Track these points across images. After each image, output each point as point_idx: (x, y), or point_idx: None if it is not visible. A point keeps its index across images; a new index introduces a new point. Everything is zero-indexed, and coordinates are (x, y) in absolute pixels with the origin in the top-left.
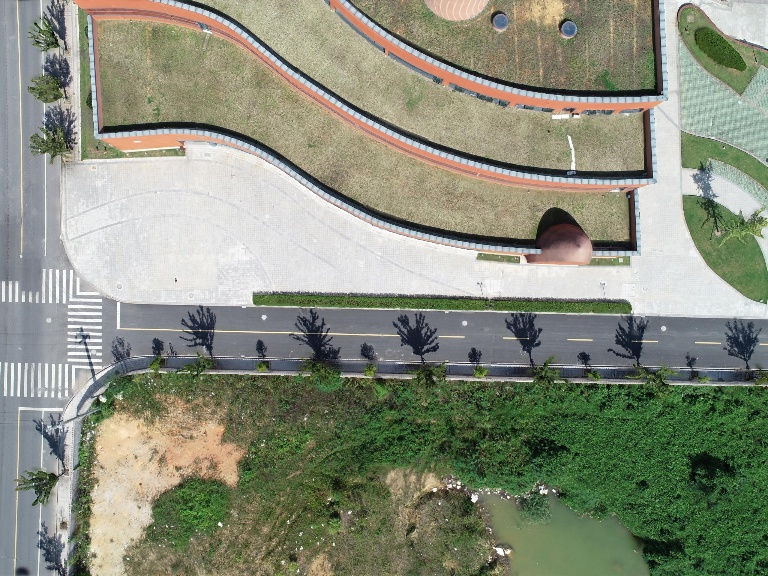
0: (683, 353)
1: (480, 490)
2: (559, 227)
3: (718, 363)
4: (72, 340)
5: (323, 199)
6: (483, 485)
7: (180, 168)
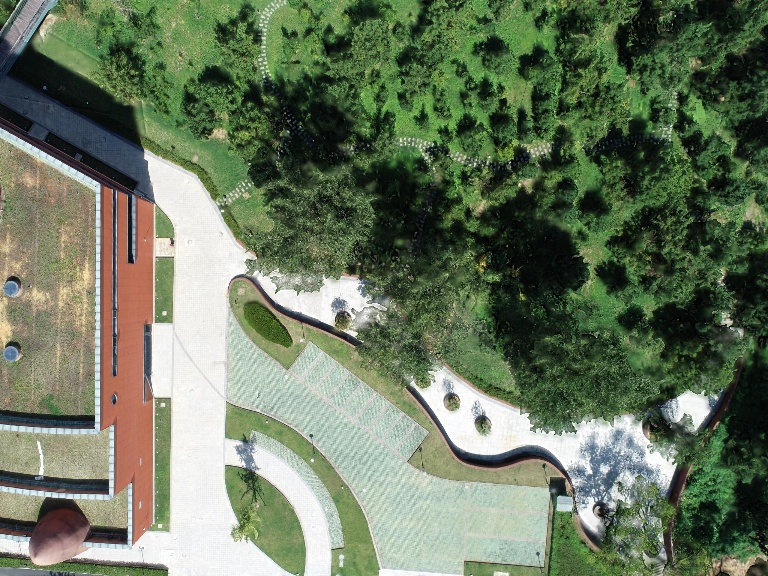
0: None
1: None
2: (47, 518)
3: None
4: None
5: None
6: None
7: None
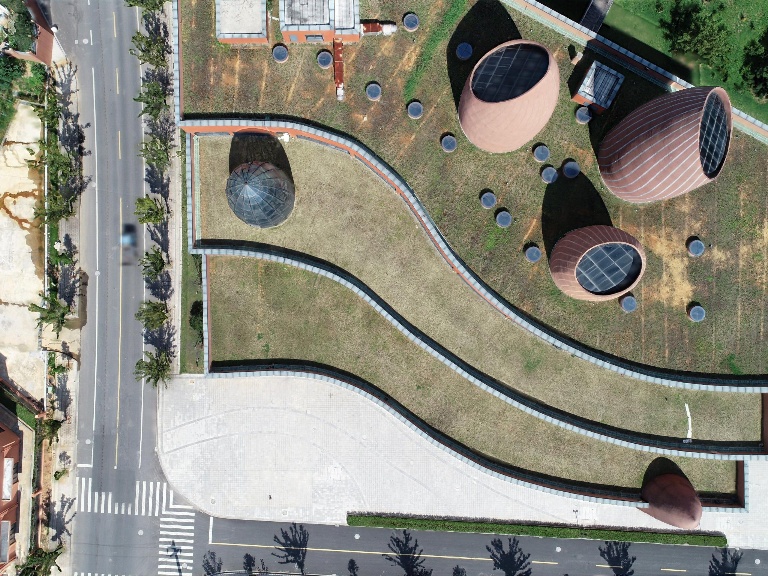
0: None
1: None
2: (668, 483)
3: None
4: (163, 553)
5: None
6: None
7: (279, 385)
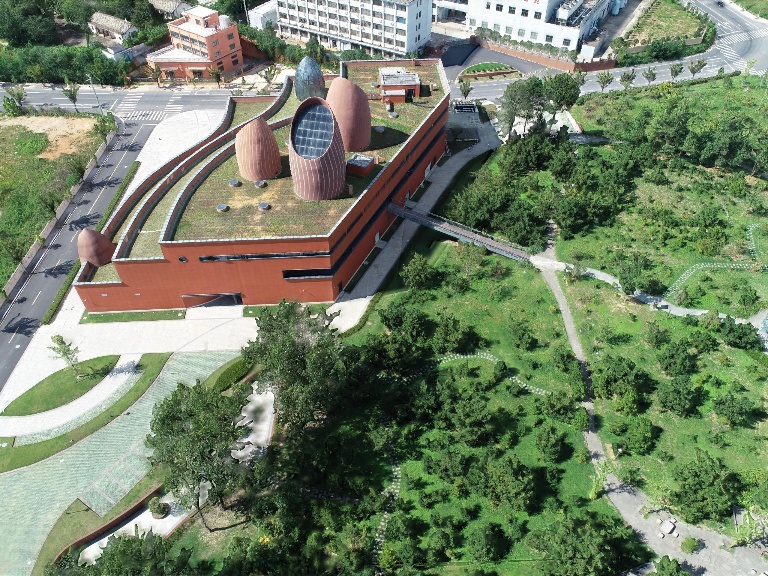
0: None
1: None
2: (111, 243)
3: None
4: (144, 112)
5: None
6: None
7: None
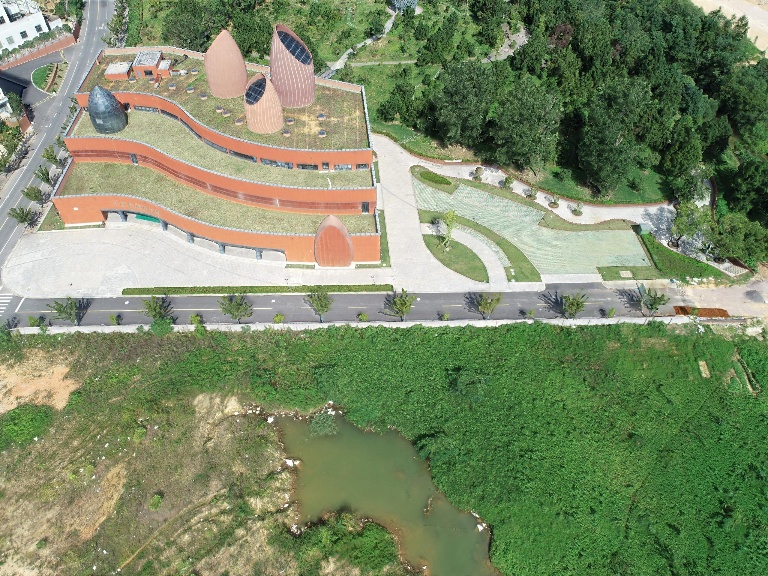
0: (434, 312)
1: (276, 414)
2: None
3: (461, 317)
4: None
5: (187, 241)
6: (277, 405)
7: (99, 233)
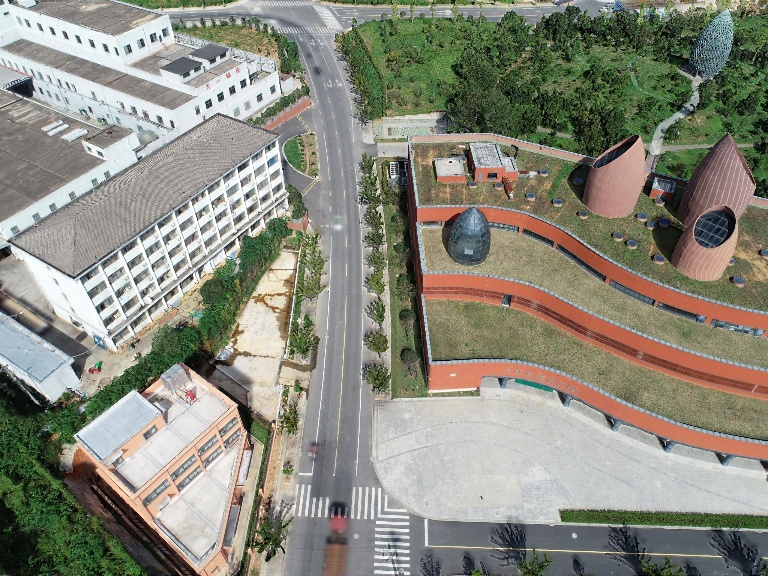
0: None
1: None
2: None
3: None
4: (379, 557)
5: (607, 427)
6: None
7: (476, 405)
